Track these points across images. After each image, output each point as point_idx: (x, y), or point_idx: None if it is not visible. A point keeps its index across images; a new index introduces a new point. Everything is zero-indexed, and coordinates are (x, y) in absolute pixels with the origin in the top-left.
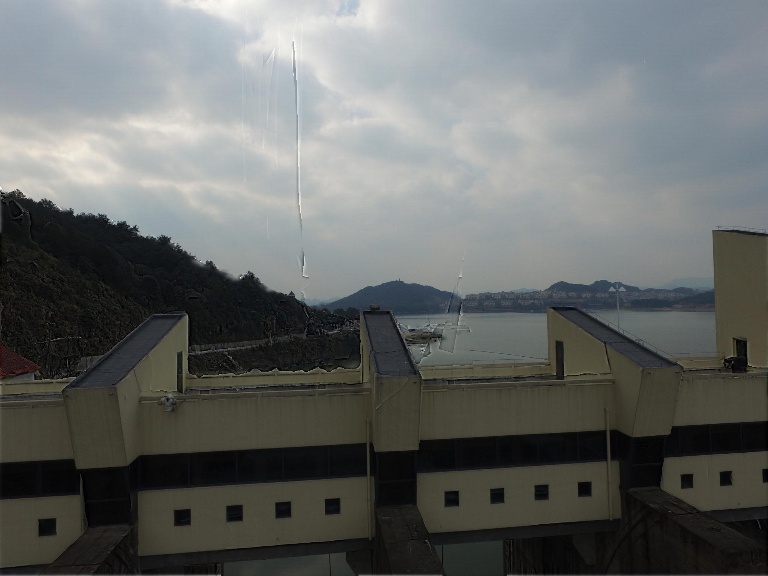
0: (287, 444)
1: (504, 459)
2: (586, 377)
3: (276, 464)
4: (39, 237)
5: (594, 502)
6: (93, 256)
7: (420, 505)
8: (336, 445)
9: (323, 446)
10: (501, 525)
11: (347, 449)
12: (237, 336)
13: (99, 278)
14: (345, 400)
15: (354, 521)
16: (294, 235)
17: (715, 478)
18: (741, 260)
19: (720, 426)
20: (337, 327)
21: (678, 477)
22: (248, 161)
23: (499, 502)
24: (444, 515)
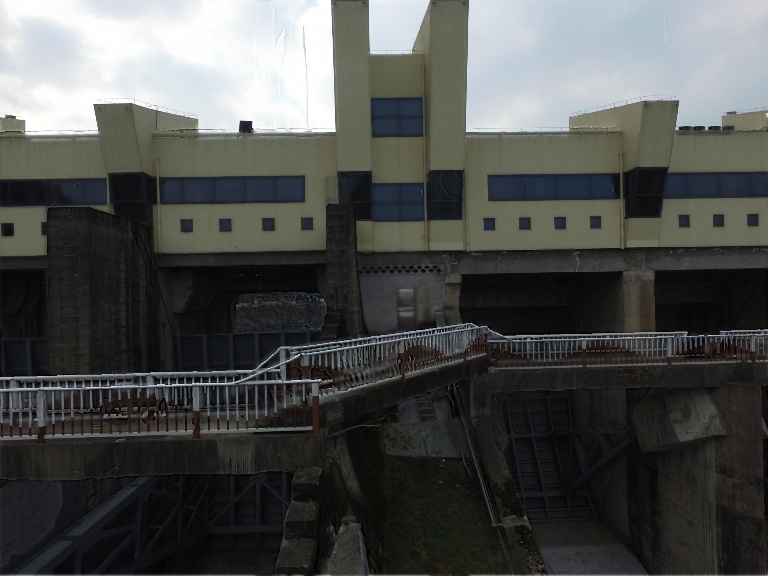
0: None
1: (16, 200)
2: (92, 132)
3: None
4: None
5: None
6: None
7: None
8: None
9: None
10: (11, 254)
11: None
12: None
13: None
14: None
15: None
16: None
17: (214, 224)
18: None
19: (222, 179)
20: None
21: (178, 221)
22: None
23: (10, 235)
24: None
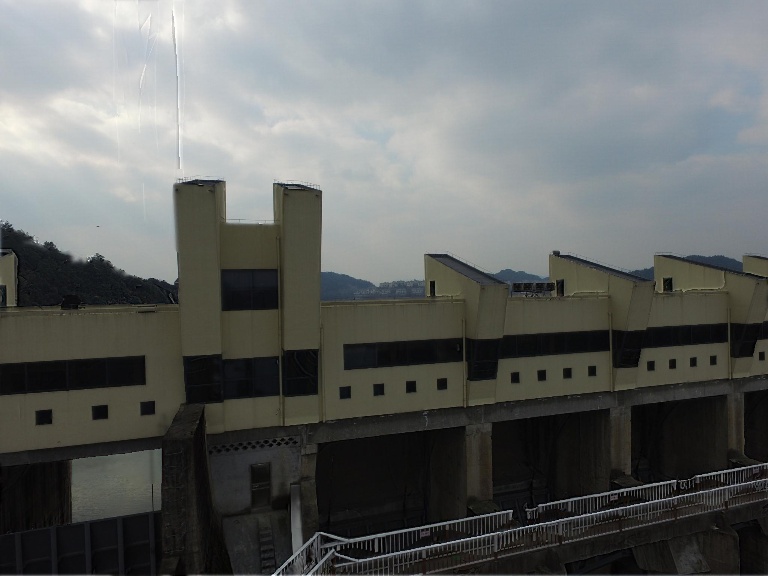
0: None
1: None
2: None
3: None
4: None
5: None
6: None
7: None
8: None
9: None
10: None
11: None
12: None
13: None
14: None
15: None
16: None
17: (29, 417)
18: None
19: (39, 364)
20: None
21: None
22: (123, 136)
23: None
24: None
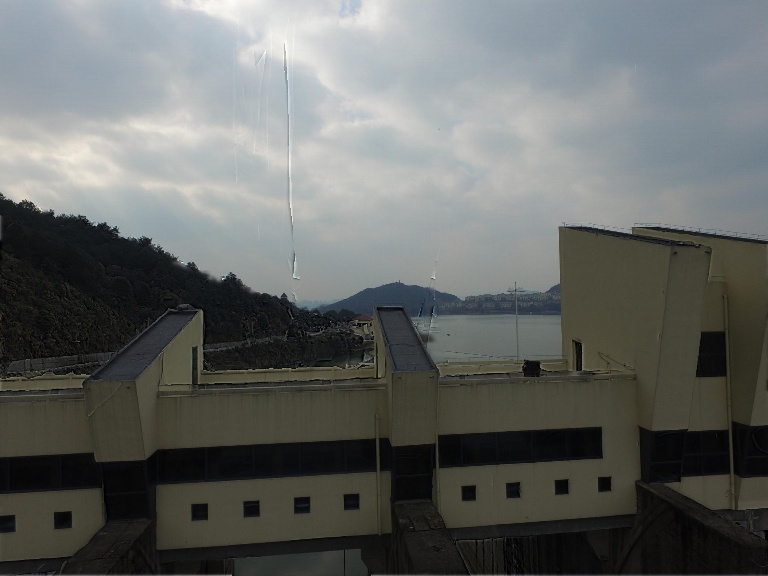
0: (13, 453)
1: (261, 469)
2: (356, 382)
3: (2, 474)
4: (1, 238)
5: (362, 515)
6: (59, 257)
7: (163, 519)
8: (69, 454)
9: (54, 455)
10: (256, 540)
11: (82, 458)
12: (214, 338)
13: (64, 279)
14: (80, 406)
15: (88, 536)
16: (285, 237)
17: (501, 490)
18: (577, 258)
19: (508, 434)
20: (322, 329)
21: (458, 489)
22: (240, 163)
23: (254, 515)
24: (191, 529)
